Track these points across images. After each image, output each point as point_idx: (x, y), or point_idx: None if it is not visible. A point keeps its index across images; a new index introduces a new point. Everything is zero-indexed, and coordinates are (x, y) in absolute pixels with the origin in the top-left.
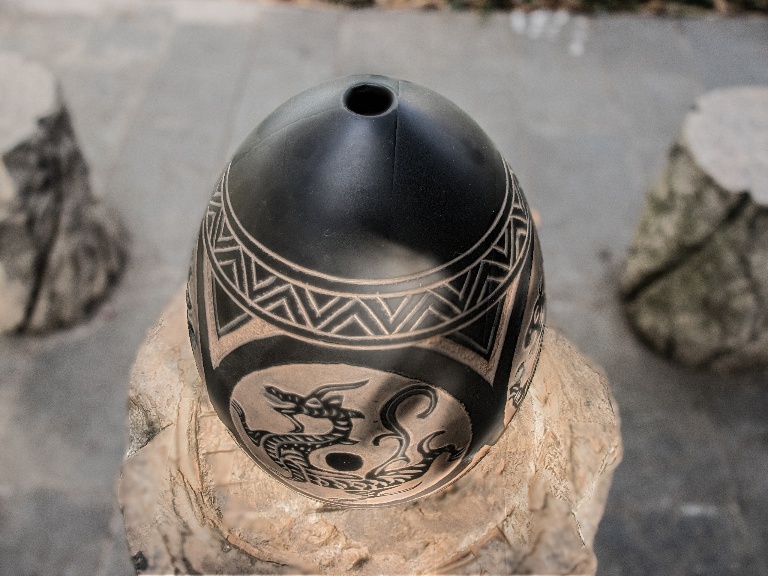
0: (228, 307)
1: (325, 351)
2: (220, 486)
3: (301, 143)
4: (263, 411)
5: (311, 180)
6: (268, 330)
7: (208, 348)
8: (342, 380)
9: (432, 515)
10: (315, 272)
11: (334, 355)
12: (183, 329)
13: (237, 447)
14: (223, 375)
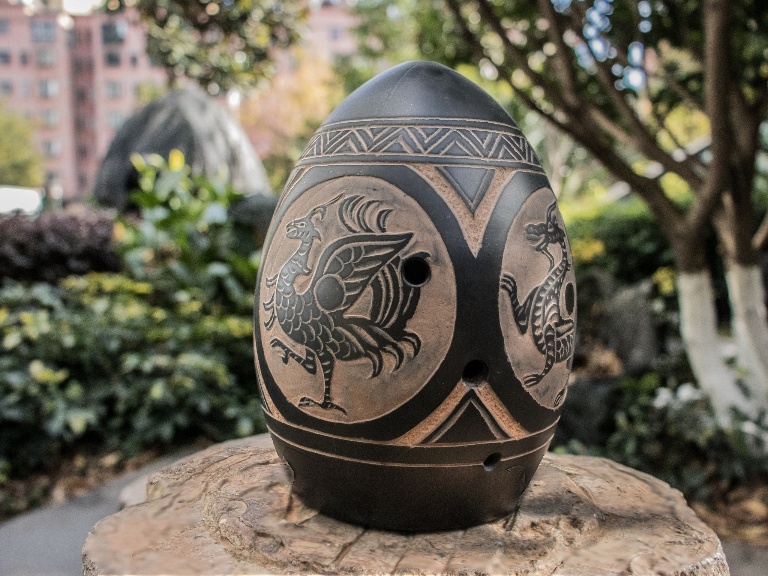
0: (472, 176)
1: (537, 177)
2: (447, 568)
3: (429, 72)
4: (530, 260)
5: (458, 81)
6: (506, 175)
7: (463, 239)
8: (550, 201)
9: (542, 482)
10: (504, 124)
11: (540, 180)
12: (174, 569)
13: (399, 553)
14: (489, 251)
